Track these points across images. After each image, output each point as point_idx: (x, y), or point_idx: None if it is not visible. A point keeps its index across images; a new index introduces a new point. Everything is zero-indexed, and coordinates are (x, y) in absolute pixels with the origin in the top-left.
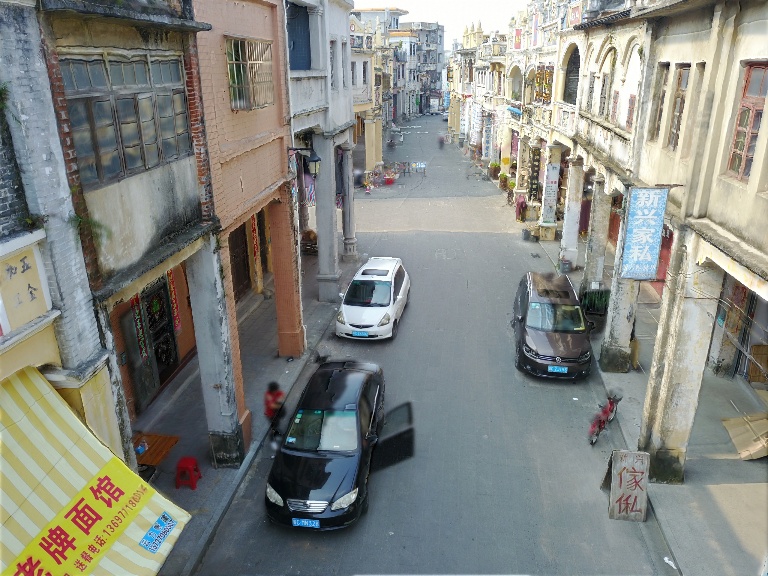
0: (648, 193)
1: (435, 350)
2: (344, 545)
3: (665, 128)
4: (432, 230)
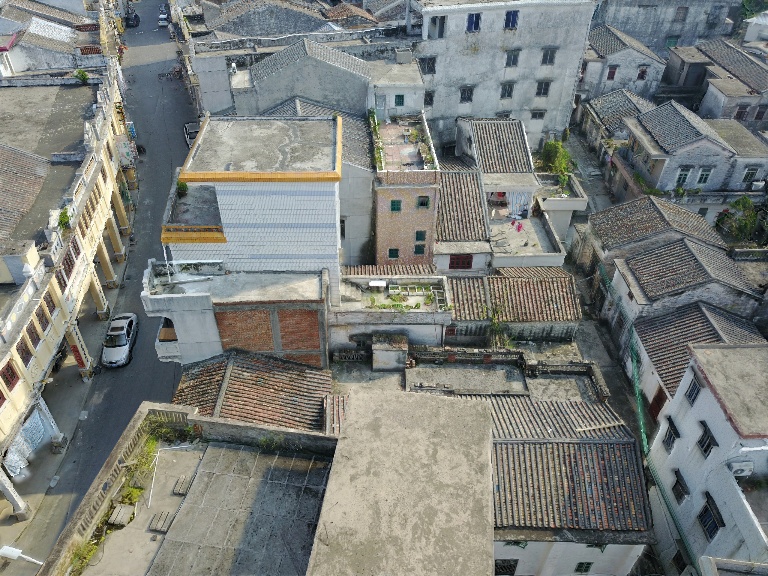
0: None
1: None
2: None
3: None
4: None
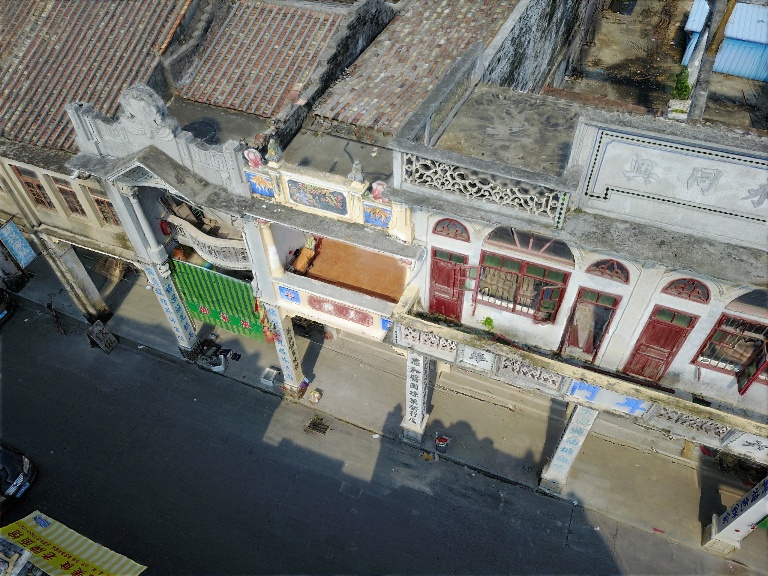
0: (6, 228)
1: None
2: (44, 477)
3: None
4: None
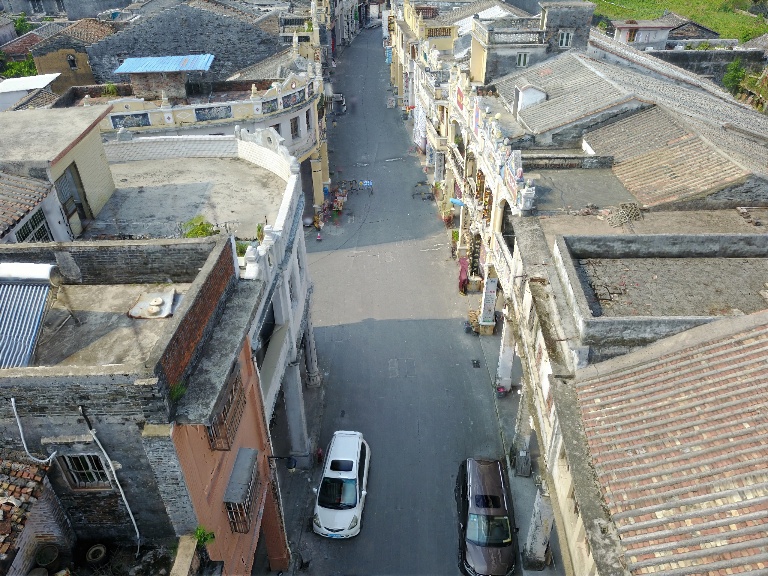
0: None
1: (395, 543)
2: None
3: (570, 488)
4: (384, 319)
